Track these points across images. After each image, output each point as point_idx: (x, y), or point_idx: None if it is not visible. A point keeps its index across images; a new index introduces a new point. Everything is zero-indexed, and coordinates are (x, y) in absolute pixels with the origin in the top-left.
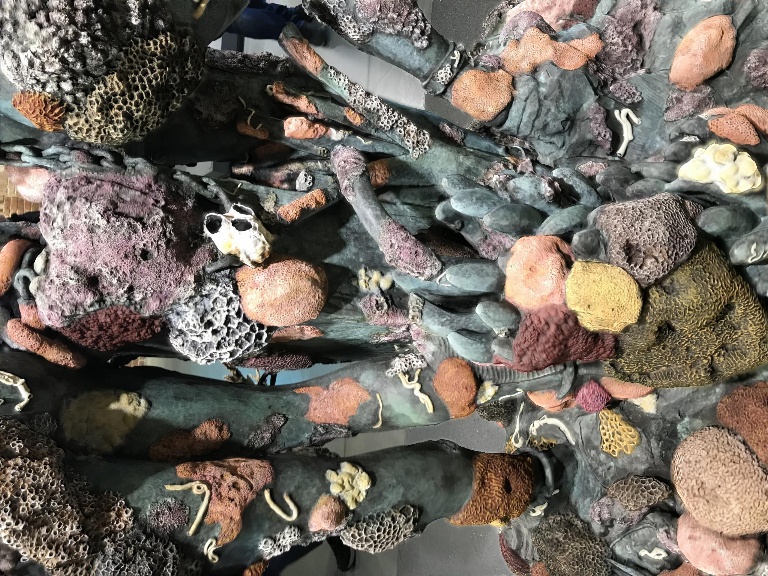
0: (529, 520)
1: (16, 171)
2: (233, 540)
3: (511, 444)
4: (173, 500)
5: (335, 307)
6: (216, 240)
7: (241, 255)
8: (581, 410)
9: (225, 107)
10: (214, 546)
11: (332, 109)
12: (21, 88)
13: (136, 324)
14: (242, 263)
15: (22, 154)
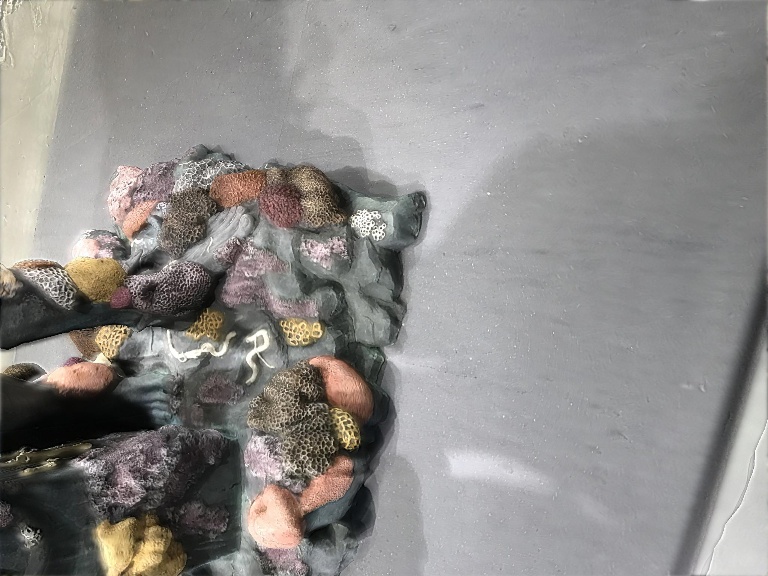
0: (189, 254)
1: None
2: None
3: (302, 335)
4: None
5: None
6: None
7: None
8: (160, 361)
9: None
10: None
11: None
12: None
13: None
14: None
15: None
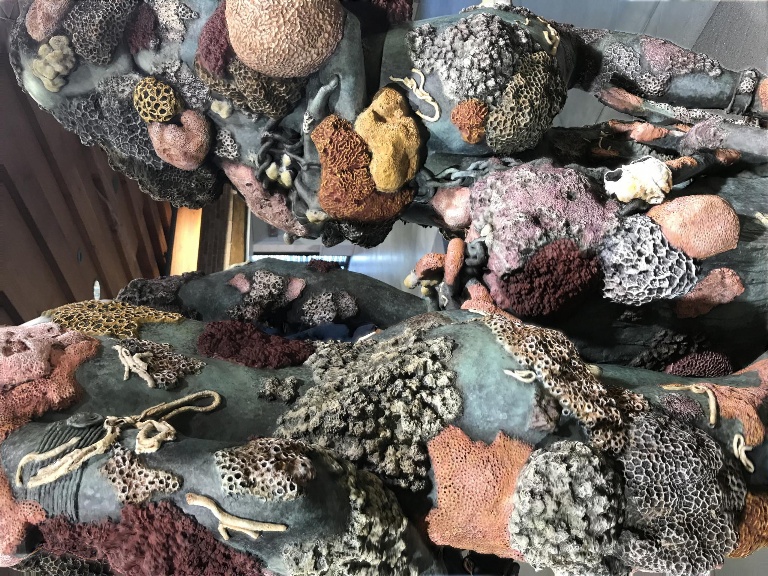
0: None
1: (445, 196)
2: (761, 444)
3: None
4: (677, 394)
5: (750, 238)
6: (620, 188)
7: (649, 188)
8: None
9: (576, 145)
10: (743, 445)
11: (663, 126)
12: (458, 100)
13: (577, 261)
14: (648, 206)
15: (452, 174)
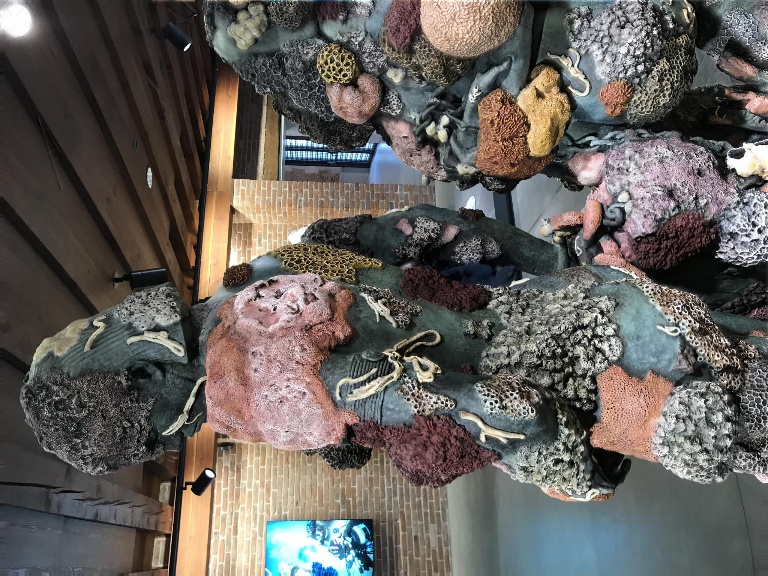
0: None
1: (582, 159)
2: None
3: None
4: None
5: None
6: (741, 165)
7: (767, 167)
8: None
9: (694, 111)
10: None
11: None
12: (609, 80)
13: (700, 229)
14: (763, 181)
15: (591, 141)
